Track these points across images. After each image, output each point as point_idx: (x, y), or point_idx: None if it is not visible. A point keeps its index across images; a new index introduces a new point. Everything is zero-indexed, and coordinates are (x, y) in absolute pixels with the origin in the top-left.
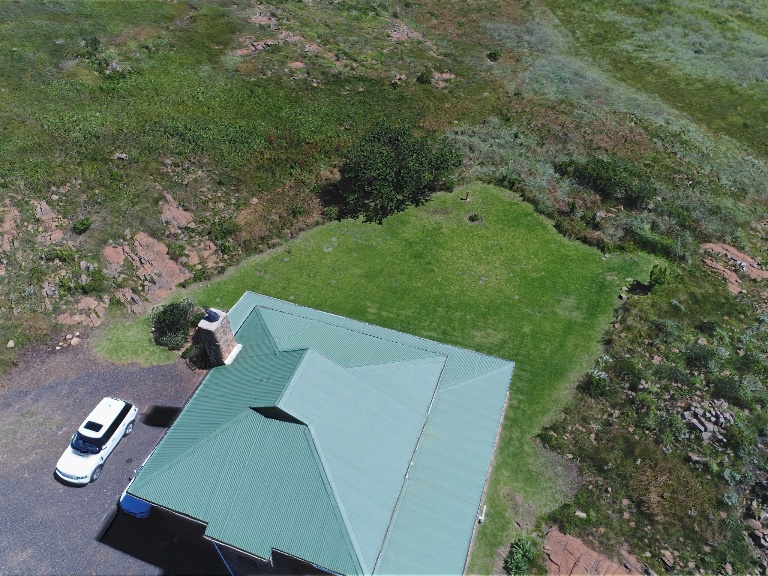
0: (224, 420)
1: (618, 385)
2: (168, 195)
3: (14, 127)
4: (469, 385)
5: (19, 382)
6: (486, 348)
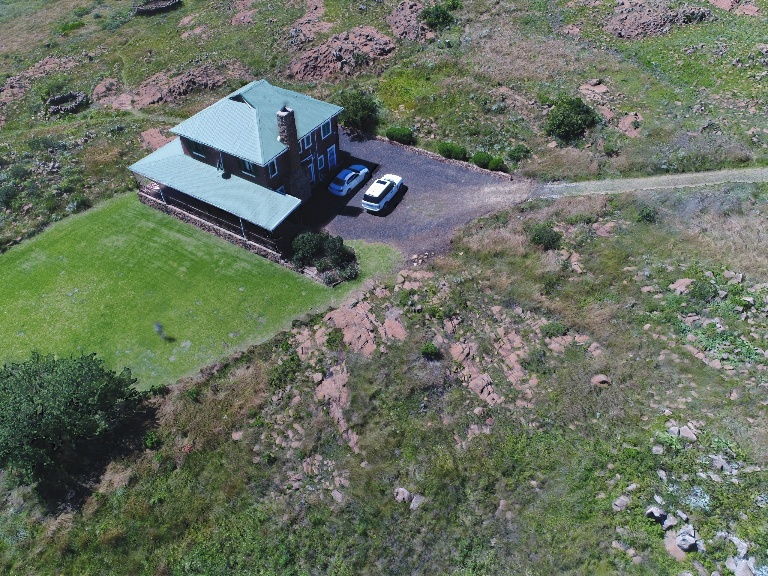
0: (291, 97)
1: (68, 200)
2: (340, 416)
3: (599, 570)
4: (163, 158)
5: (446, 233)
6: (123, 233)
